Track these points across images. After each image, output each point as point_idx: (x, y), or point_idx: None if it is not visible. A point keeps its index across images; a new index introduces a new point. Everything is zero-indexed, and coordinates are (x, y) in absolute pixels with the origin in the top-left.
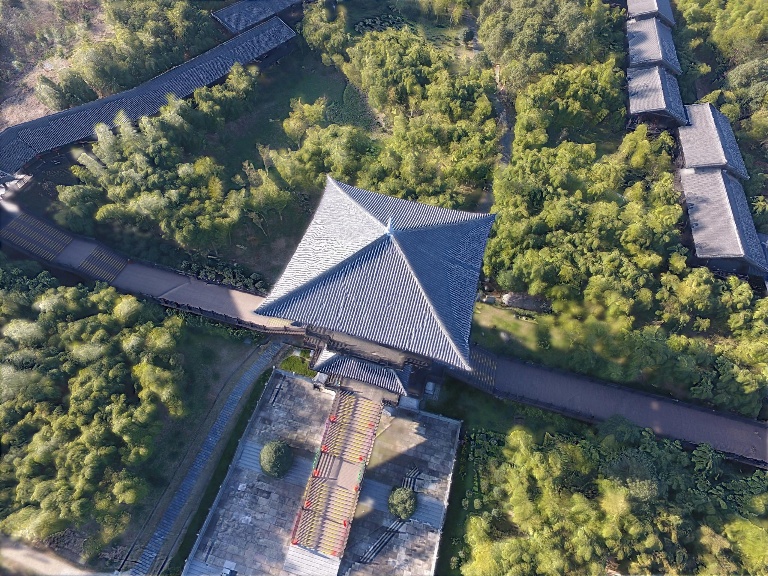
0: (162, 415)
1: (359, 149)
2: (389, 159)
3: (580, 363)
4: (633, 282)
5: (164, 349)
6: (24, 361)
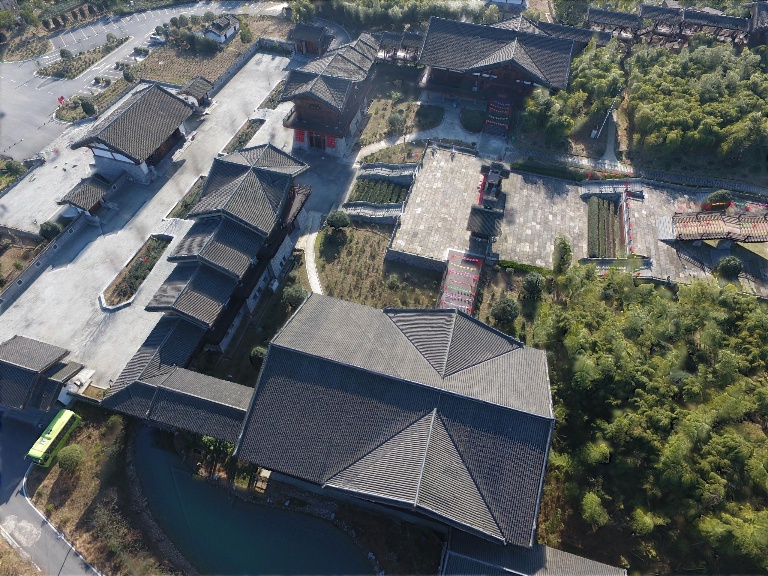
0: (716, 143)
1: None
2: None
3: None
4: None
5: (759, 131)
6: (715, 85)
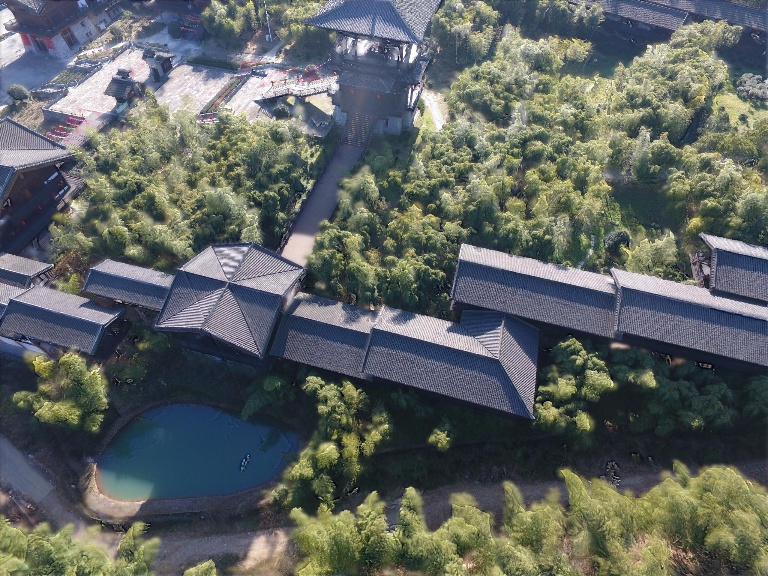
0: None
1: (537, 66)
2: (521, 67)
3: None
4: None
5: None
6: None
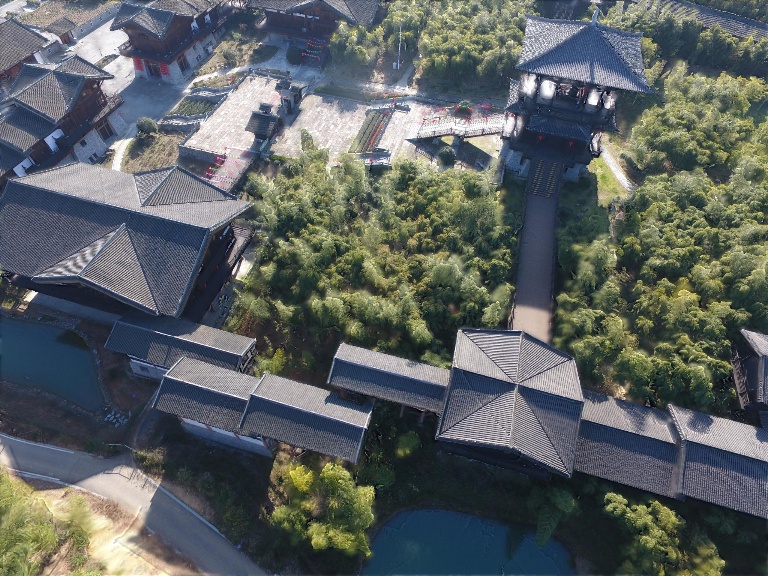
0: None
1: (724, 108)
2: (717, 111)
3: None
4: (666, 259)
5: (510, 56)
6: (491, 22)
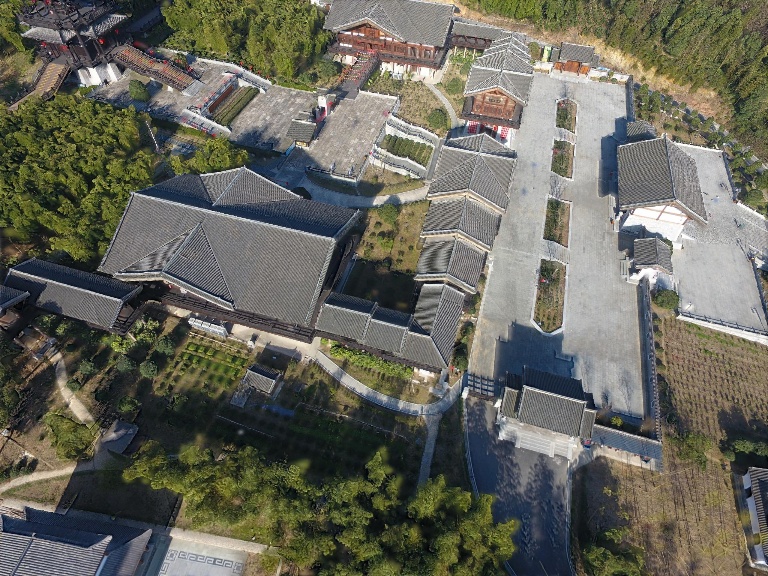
0: None
1: None
2: None
3: (141, 3)
4: None
5: (45, 101)
6: None
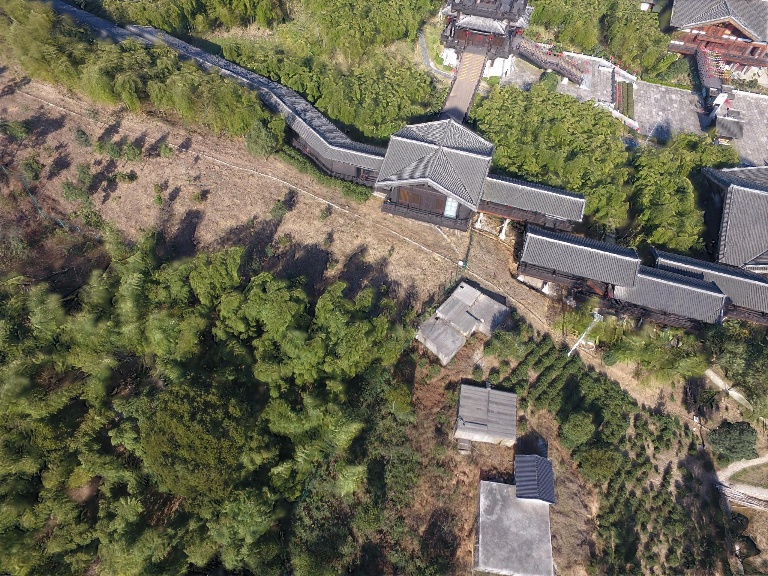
0: None
1: None
2: None
3: None
4: None
5: None
6: None
